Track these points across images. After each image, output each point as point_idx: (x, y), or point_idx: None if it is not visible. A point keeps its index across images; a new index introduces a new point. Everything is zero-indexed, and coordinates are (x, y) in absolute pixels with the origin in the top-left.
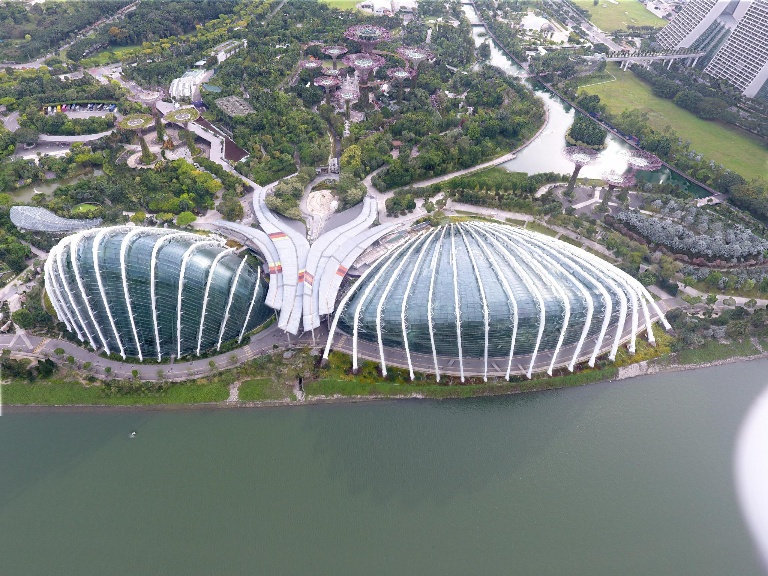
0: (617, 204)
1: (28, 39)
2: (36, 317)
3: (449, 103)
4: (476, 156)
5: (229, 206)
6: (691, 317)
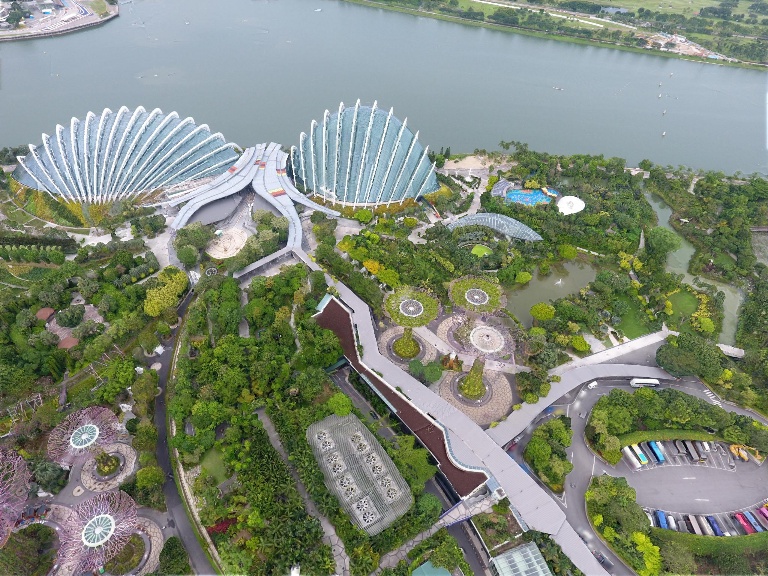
0: None
1: None
2: (440, 174)
3: None
4: None
5: (324, 218)
6: (7, 152)
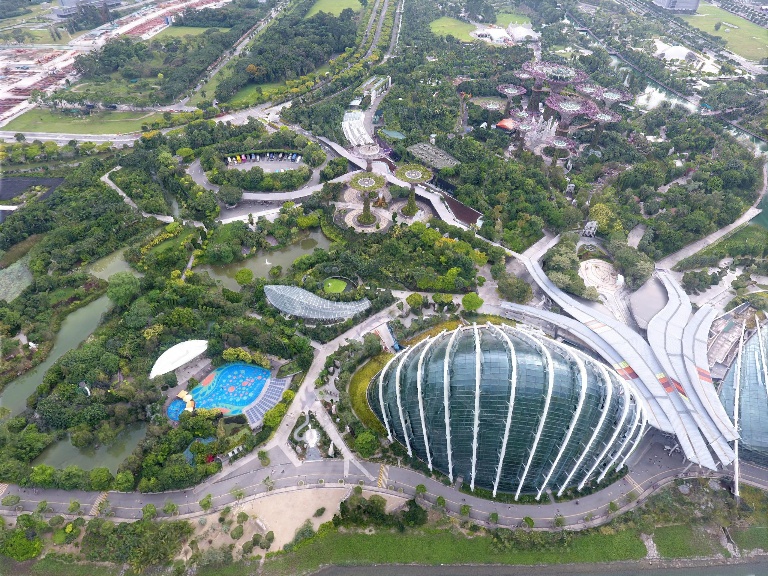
0: None
1: (161, 78)
2: None
3: (659, 148)
4: (735, 214)
5: (515, 285)
6: None
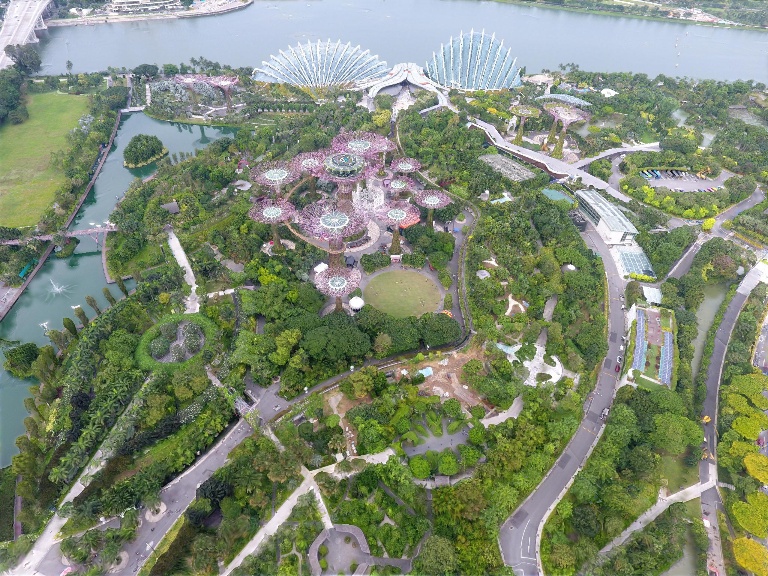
0: (207, 105)
1: None
2: None
3: None
4: None
5: (457, 93)
6: (243, 69)
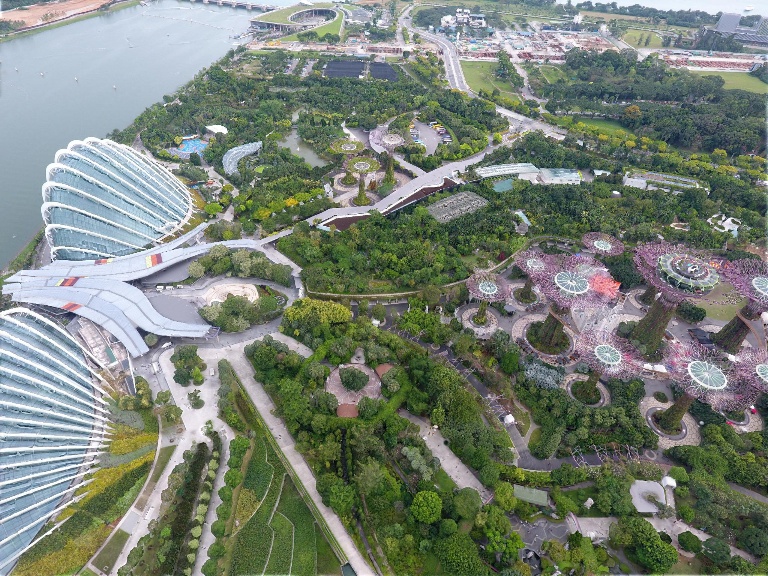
0: None
1: None
2: None
3: (581, 471)
4: None
5: None
6: None
